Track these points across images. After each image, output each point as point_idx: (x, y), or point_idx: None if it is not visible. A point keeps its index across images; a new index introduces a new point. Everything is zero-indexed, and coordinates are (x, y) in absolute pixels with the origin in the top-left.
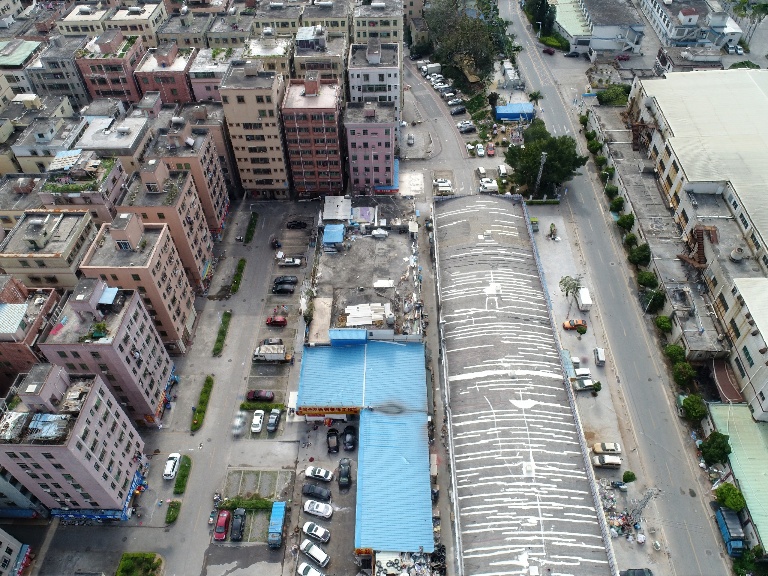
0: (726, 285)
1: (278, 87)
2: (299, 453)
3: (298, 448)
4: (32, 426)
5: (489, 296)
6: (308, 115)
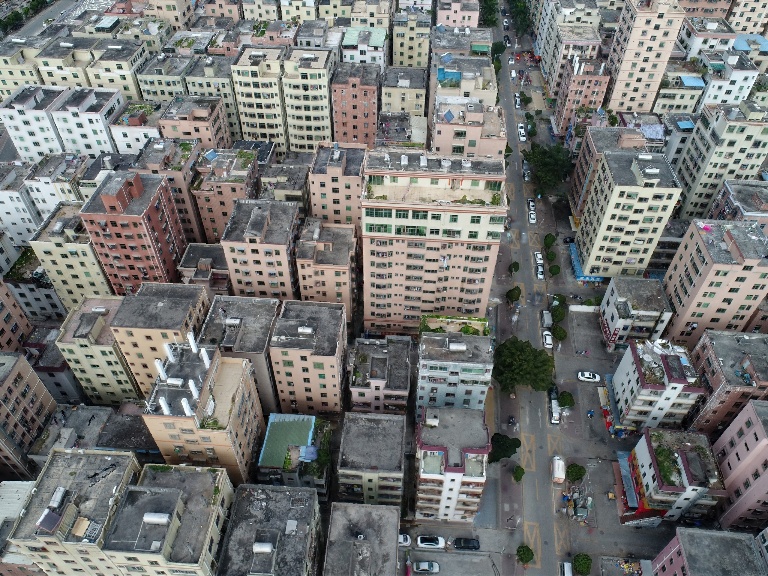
0: None
1: (150, 3)
2: (203, 3)
3: (203, 4)
4: None
5: (96, 8)
6: None
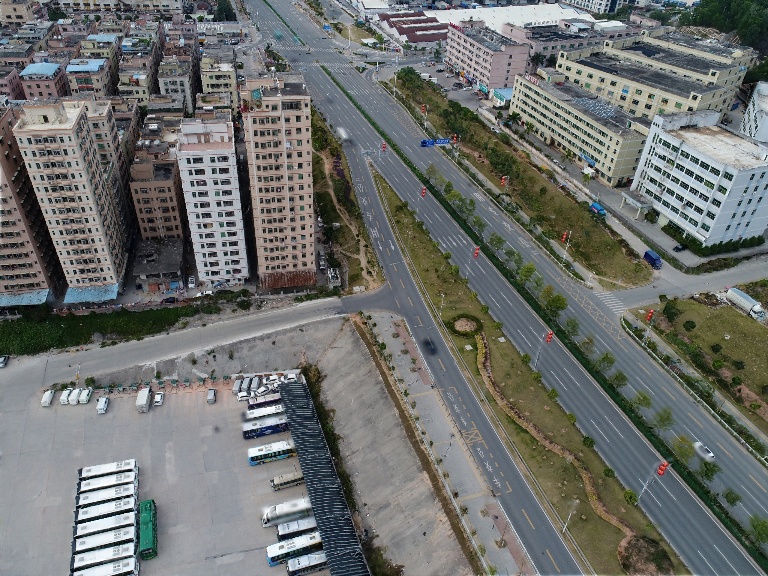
0: (143, 1)
1: None
2: None
3: None
4: (190, 21)
5: None
6: (38, 10)
